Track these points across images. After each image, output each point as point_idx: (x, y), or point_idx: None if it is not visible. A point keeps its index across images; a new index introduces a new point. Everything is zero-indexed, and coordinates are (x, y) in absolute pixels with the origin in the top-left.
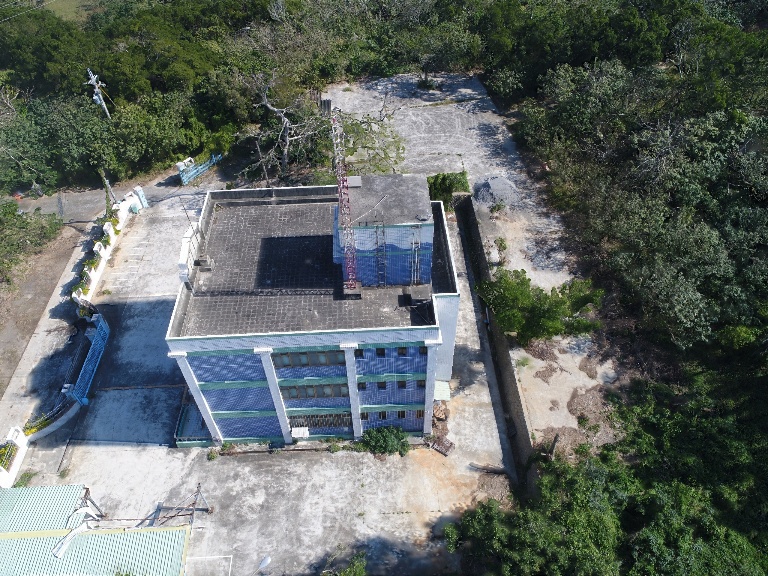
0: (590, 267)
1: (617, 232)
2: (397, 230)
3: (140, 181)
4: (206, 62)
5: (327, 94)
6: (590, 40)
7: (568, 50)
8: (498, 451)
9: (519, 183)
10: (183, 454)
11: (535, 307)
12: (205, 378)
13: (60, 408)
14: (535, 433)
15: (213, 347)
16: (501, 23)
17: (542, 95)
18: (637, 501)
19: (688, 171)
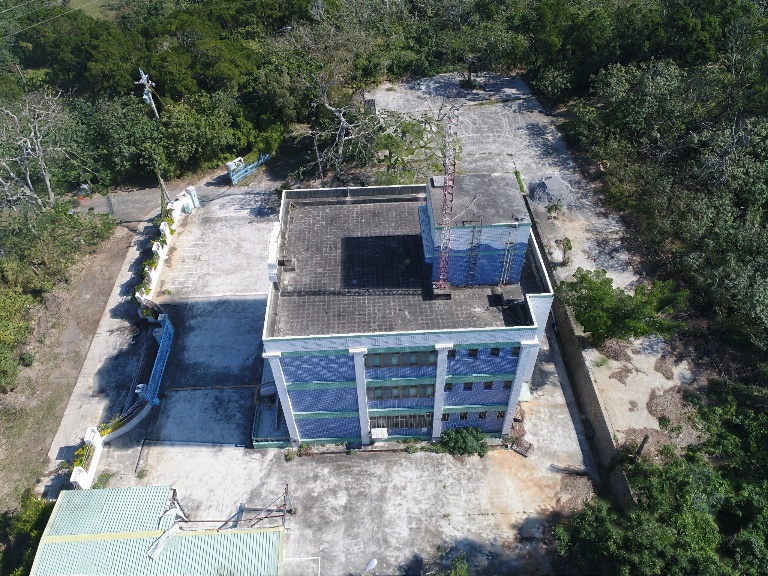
0: (655, 267)
1: (686, 232)
2: (494, 230)
3: (188, 181)
4: (247, 62)
5: (370, 94)
6: (640, 40)
7: (617, 50)
8: (578, 452)
9: (574, 183)
10: (260, 455)
11: (618, 307)
12: (293, 378)
13: (134, 408)
14: (617, 434)
15: (308, 347)
16: (550, 22)
17: (588, 95)
18: (731, 503)
19: (752, 171)
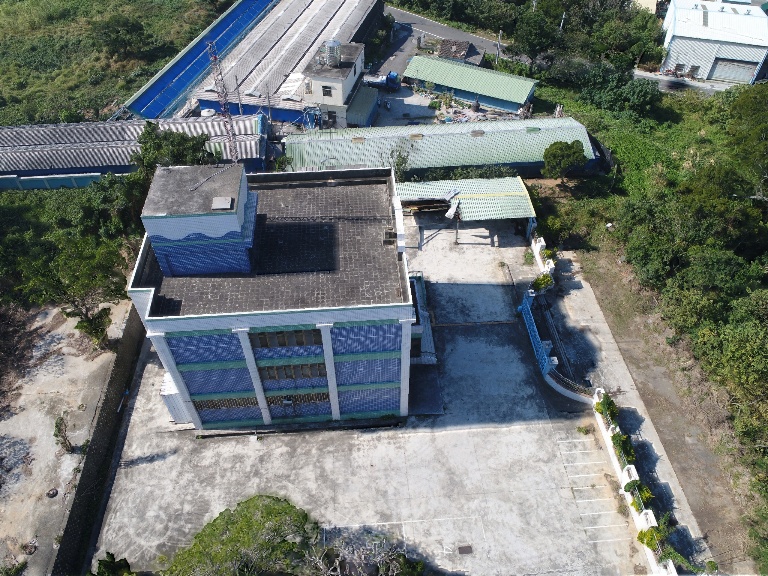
0: None
1: None
2: None
3: None
4: None
5: None
6: None
7: None
8: None
9: None
10: None
11: None
12: None
13: None
14: None
15: None
16: None
17: None
18: None
19: None
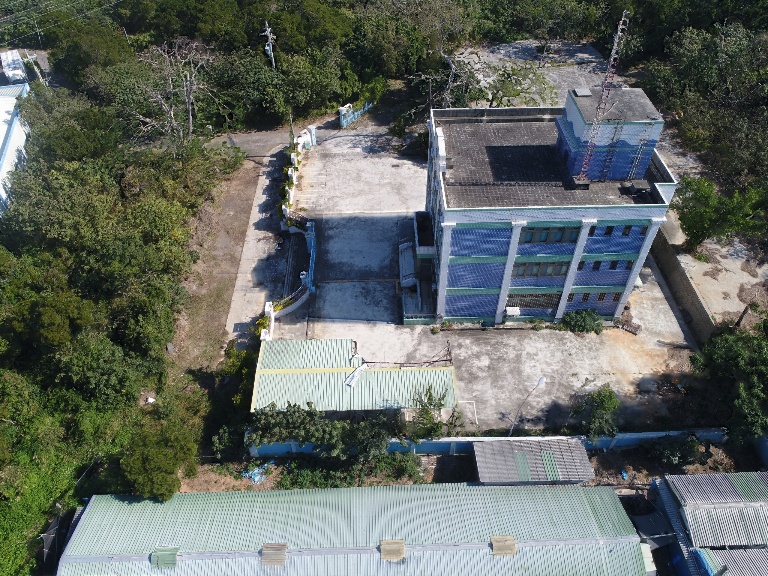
0: None
1: (765, 160)
2: (633, 127)
3: (300, 125)
4: None
5: None
6: (708, 8)
7: (686, 17)
8: (679, 332)
9: None
10: (409, 329)
11: (719, 207)
12: (456, 252)
13: (300, 291)
14: (715, 315)
15: (479, 219)
16: None
17: None
18: None
19: None
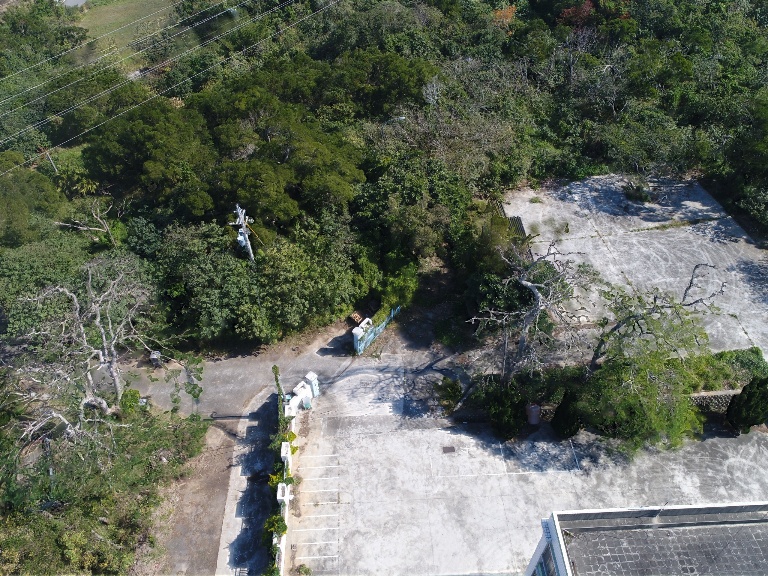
0: None
1: None
2: None
3: (294, 344)
4: (347, 160)
5: (511, 207)
6: None
7: None
8: None
9: None
10: None
11: None
12: None
13: None
14: None
15: None
16: None
17: None
18: None
19: None
